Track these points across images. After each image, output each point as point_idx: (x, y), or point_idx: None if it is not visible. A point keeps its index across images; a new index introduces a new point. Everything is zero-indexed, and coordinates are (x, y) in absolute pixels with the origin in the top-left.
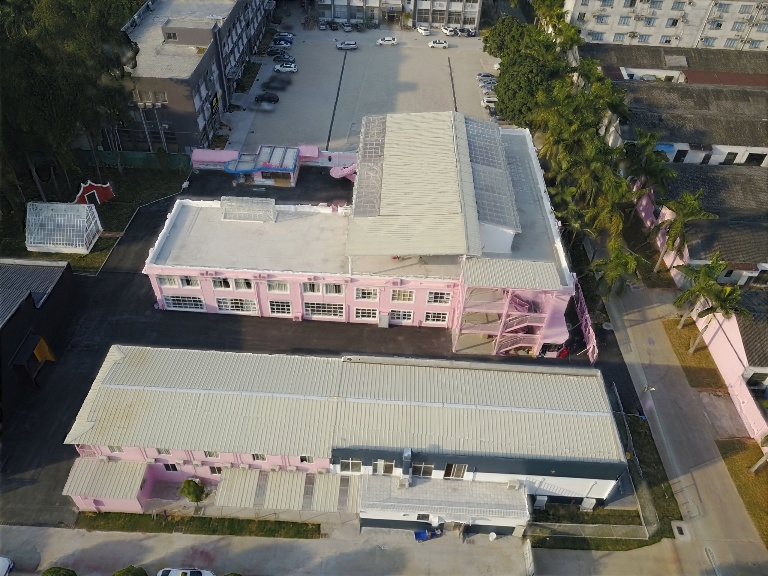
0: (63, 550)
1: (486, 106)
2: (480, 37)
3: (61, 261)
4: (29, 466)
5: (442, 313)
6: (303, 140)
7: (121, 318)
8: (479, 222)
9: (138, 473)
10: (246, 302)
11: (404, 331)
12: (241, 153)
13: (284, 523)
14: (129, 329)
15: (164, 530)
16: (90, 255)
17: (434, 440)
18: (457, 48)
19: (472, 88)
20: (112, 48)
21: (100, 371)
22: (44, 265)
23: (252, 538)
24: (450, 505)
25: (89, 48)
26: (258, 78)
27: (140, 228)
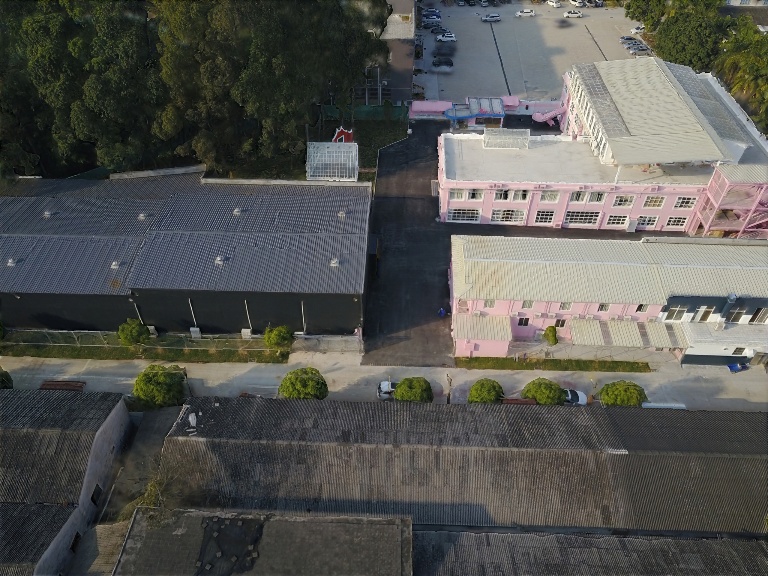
0: (456, 381)
1: None
2: (607, 7)
3: (366, 181)
4: (399, 328)
5: (683, 218)
6: (488, 96)
7: (413, 228)
8: (719, 138)
9: (506, 323)
10: (516, 213)
11: (648, 234)
12: None
13: (619, 362)
14: (424, 236)
15: (527, 368)
16: None
17: (744, 291)
18: (590, 17)
19: (618, 50)
20: (377, 9)
21: (453, 252)
22: (351, 186)
23: (598, 372)
24: (762, 340)
25: (366, 8)
26: (425, 47)
27: (389, 165)
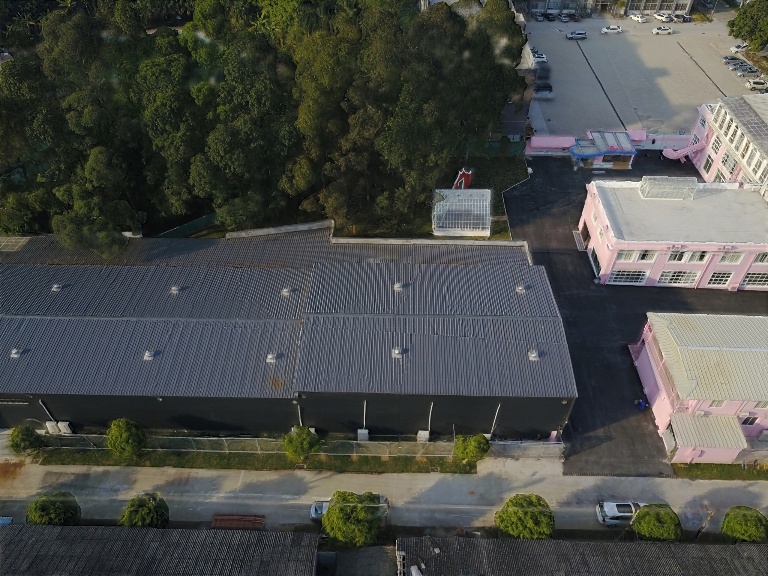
0: (683, 497)
1: (752, 88)
2: (695, 22)
3: (519, 241)
4: (595, 425)
5: None
6: (600, 126)
7: (572, 293)
8: None
9: (735, 426)
10: (688, 274)
11: None
12: (577, 139)
13: None
14: (588, 302)
15: (760, 478)
16: (493, 237)
17: None
18: (680, 34)
19: (723, 71)
20: (515, 40)
21: (658, 335)
22: (502, 245)
23: None
24: None
25: None
26: None
27: (518, 211)
